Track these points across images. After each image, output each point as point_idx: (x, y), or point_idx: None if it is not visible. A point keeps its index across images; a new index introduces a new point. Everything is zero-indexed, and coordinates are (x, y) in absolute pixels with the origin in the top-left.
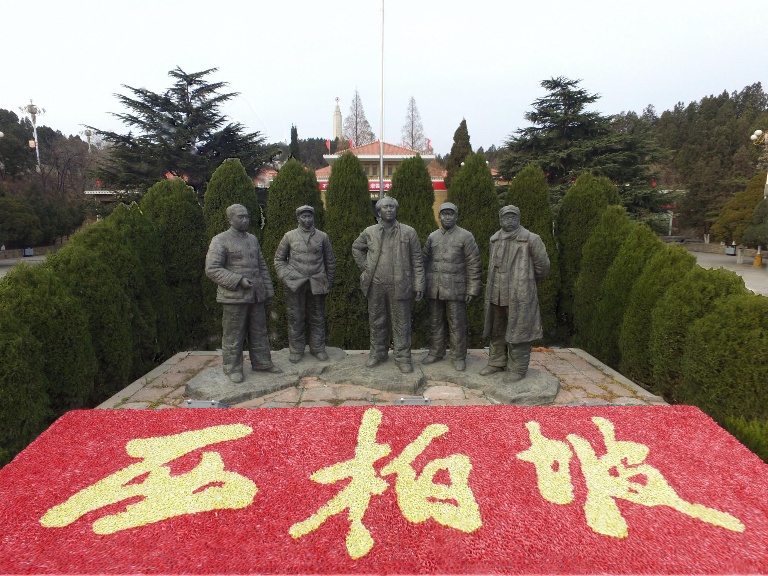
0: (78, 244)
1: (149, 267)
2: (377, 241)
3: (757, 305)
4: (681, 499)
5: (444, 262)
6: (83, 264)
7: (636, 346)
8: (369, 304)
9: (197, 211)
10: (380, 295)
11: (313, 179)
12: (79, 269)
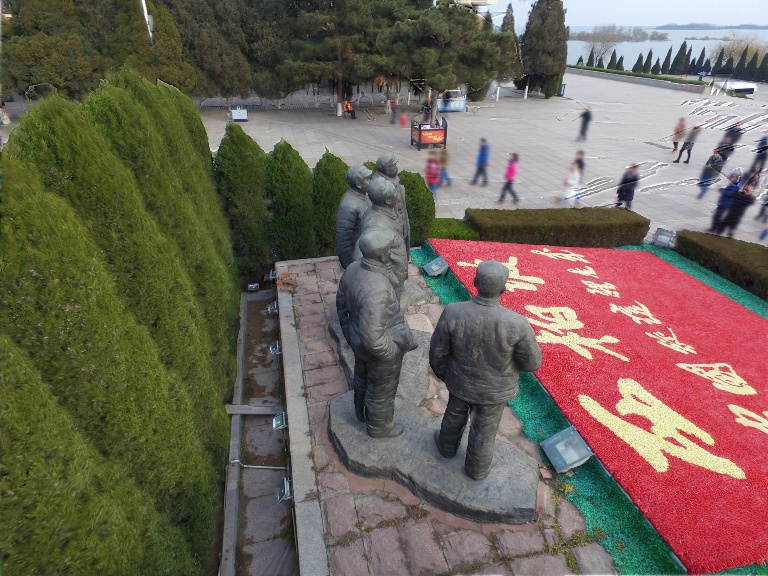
0: None
1: None
2: (398, 233)
3: None
4: None
5: None
6: None
7: None
8: None
9: None
10: None
11: None
12: None
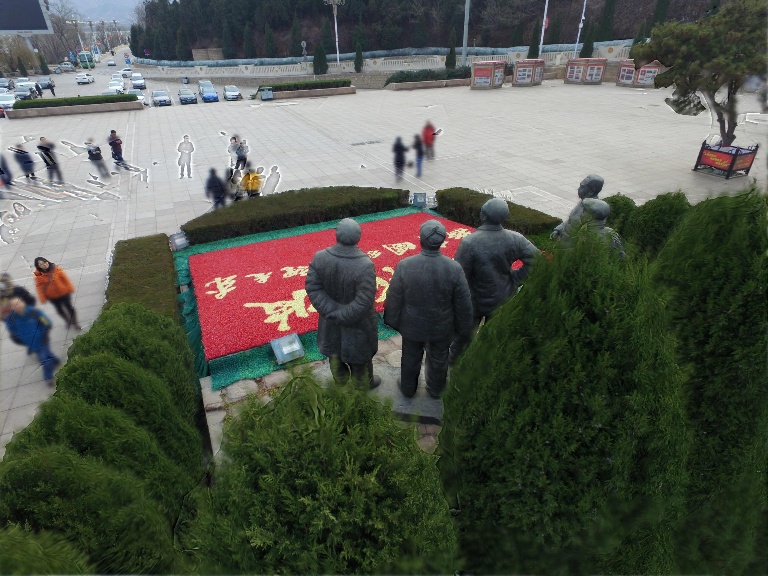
0: None
1: None
2: None
3: None
4: None
5: None
6: (696, 209)
7: None
8: None
9: None
10: None
11: None
12: (692, 212)
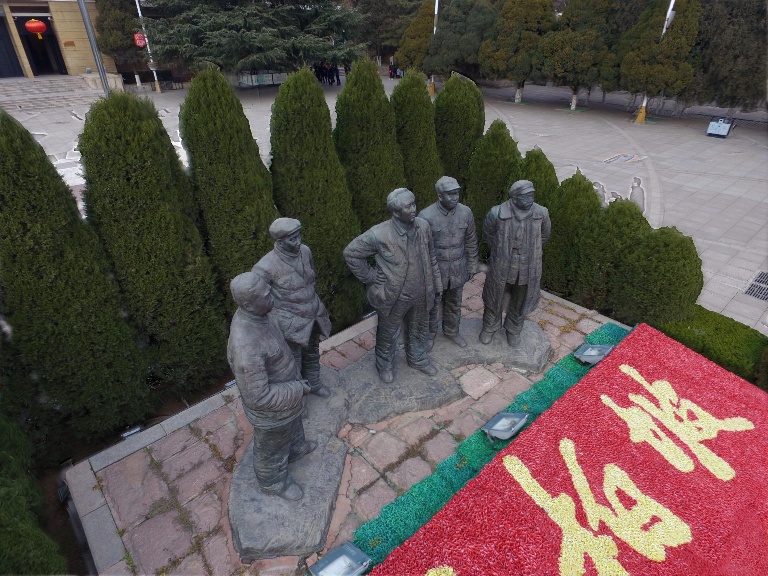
0: None
1: None
2: (401, 251)
3: (679, 241)
4: (718, 419)
5: (453, 249)
6: None
7: (557, 267)
8: (386, 320)
9: None
10: (405, 310)
11: (159, 120)
12: None
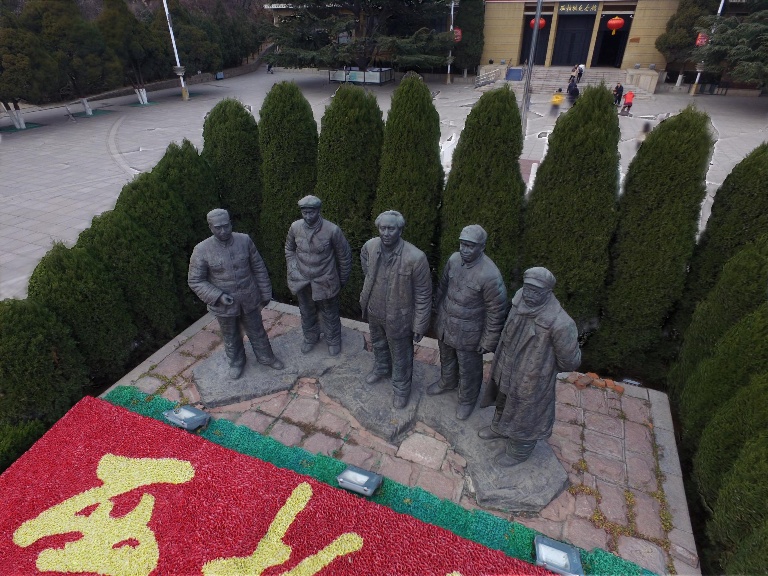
0: (123, 201)
1: (201, 211)
2: (373, 266)
3: None
4: None
5: (455, 303)
6: (115, 236)
7: (712, 462)
8: None
9: (253, 141)
10: (375, 324)
11: (371, 111)
12: (111, 241)
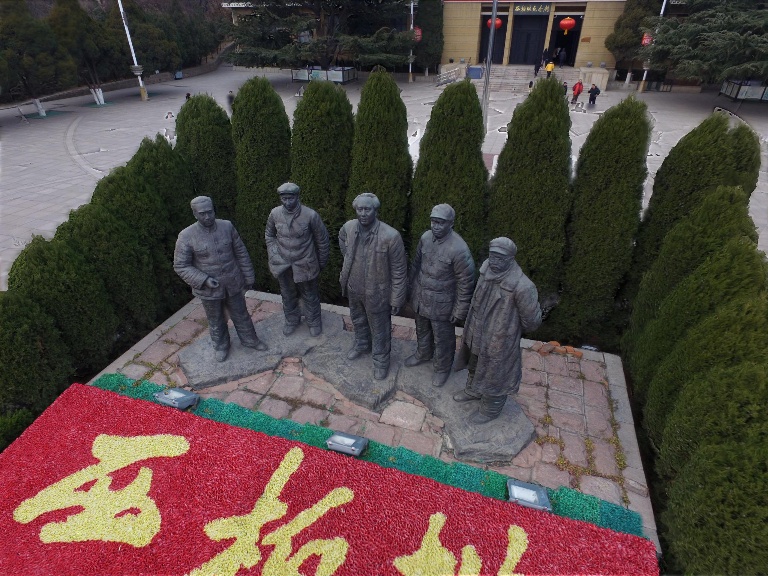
0: (100, 194)
1: (177, 204)
2: (352, 245)
3: None
4: None
5: (428, 277)
6: (94, 228)
7: (657, 407)
8: None
9: (226, 135)
10: (355, 301)
11: (341, 104)
12: (91, 233)
